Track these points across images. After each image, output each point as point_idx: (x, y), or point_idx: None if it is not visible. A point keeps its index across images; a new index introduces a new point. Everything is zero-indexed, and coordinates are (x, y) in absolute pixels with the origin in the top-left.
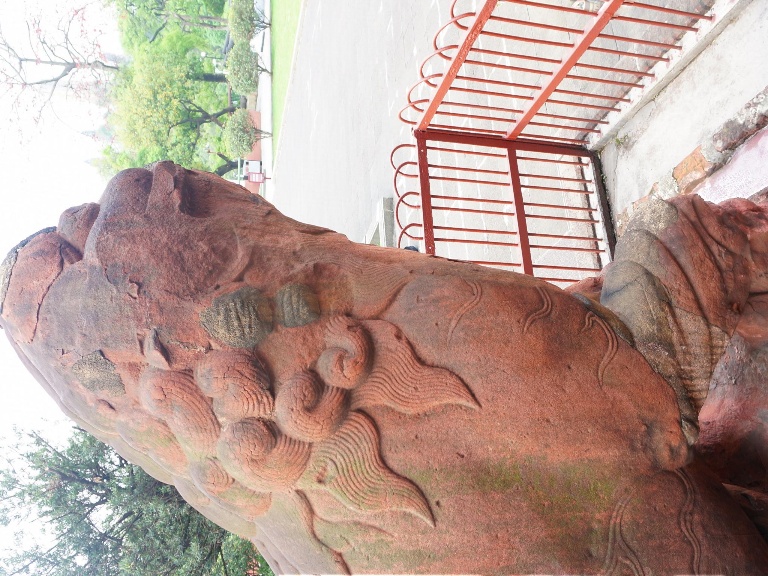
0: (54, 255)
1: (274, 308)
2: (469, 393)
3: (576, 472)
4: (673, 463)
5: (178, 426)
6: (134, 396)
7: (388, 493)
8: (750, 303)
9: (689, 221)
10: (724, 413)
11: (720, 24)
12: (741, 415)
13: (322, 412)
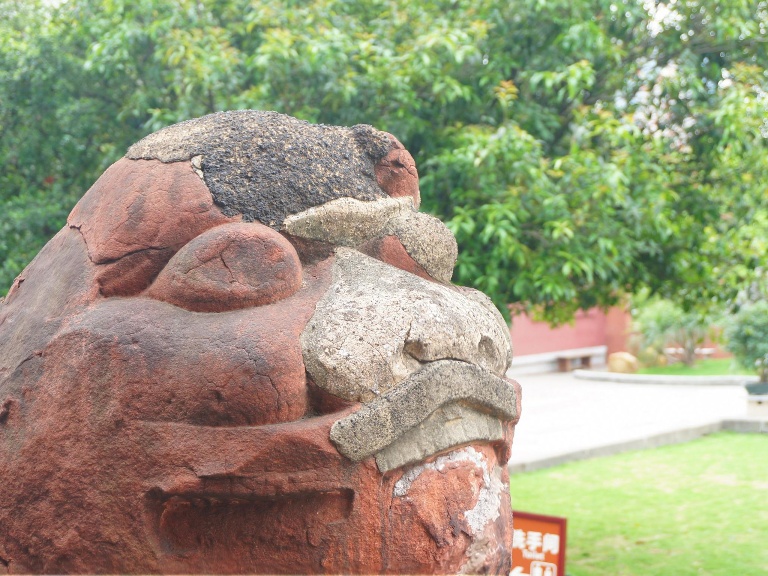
0: (123, 243)
1: None
2: None
3: None
4: None
5: None
6: None
7: None
8: None
9: None
10: None
11: None
12: None
13: None
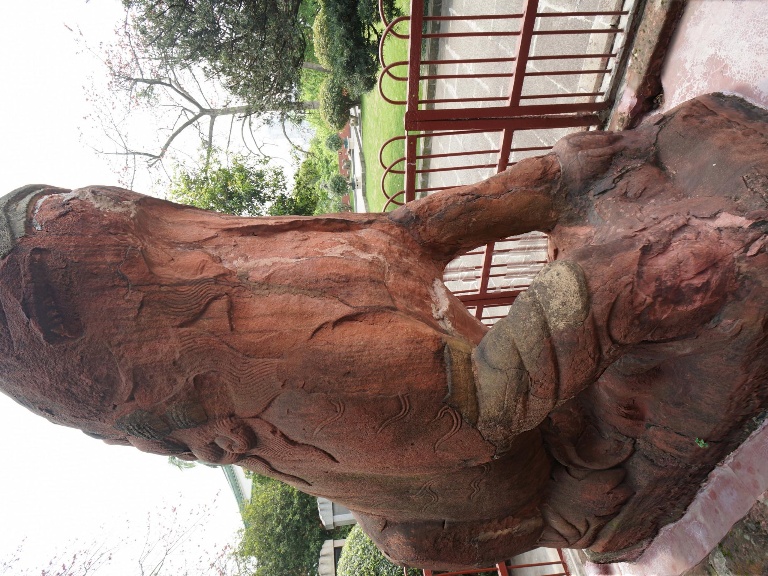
0: None
1: (167, 420)
2: (330, 458)
3: None
4: None
5: None
6: None
7: None
8: None
9: (593, 327)
10: None
11: None
12: None
13: None
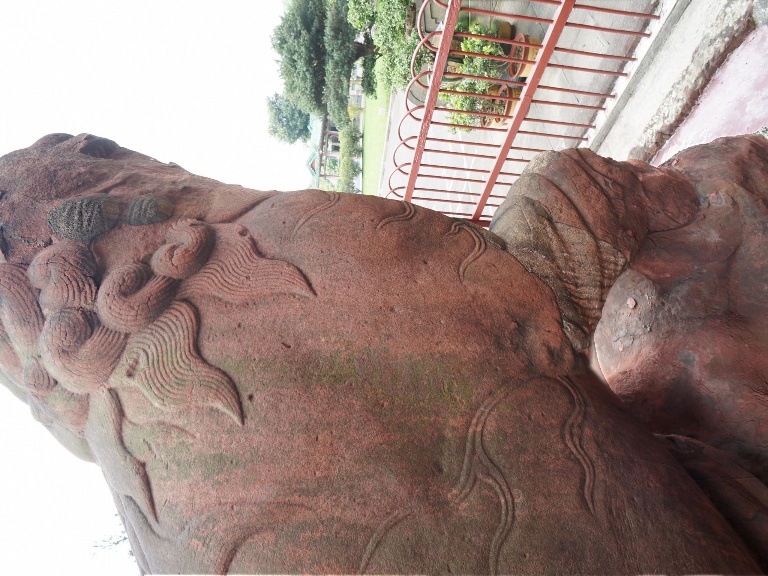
0: None
1: (124, 210)
2: (305, 281)
3: (425, 368)
4: (555, 369)
5: (7, 321)
6: None
7: (195, 385)
8: (650, 238)
9: (572, 159)
10: (641, 360)
11: (622, 99)
12: (660, 360)
13: (139, 297)
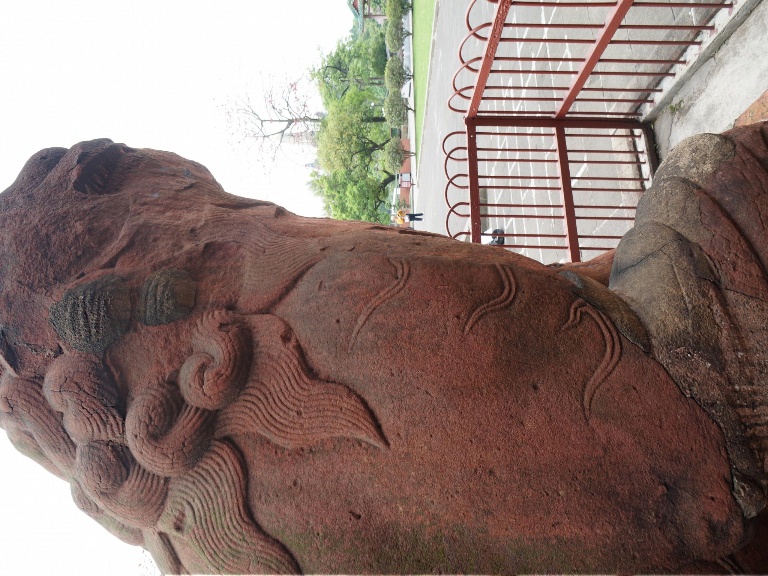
0: None
1: (136, 301)
2: (372, 424)
3: (537, 556)
4: (715, 548)
5: None
6: None
7: (252, 560)
8: None
9: (755, 158)
10: None
11: None
12: None
13: (171, 442)
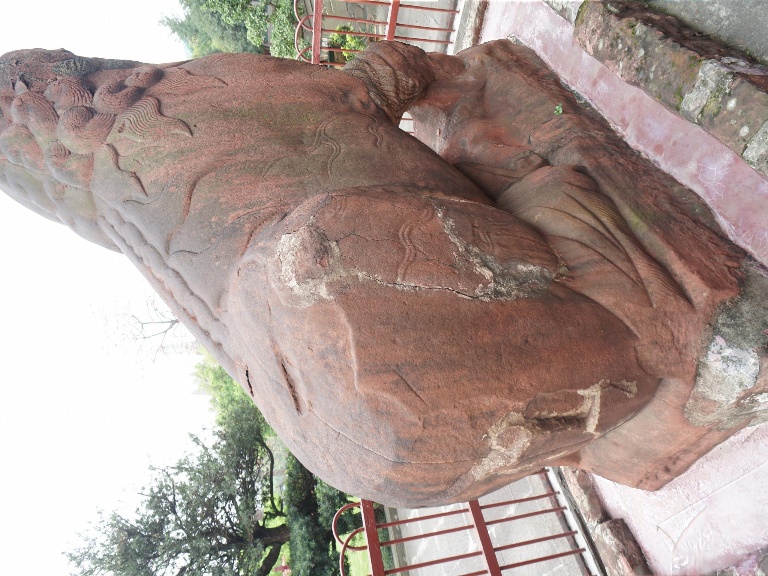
0: None
1: (102, 64)
2: None
3: (293, 109)
4: (366, 111)
5: (33, 123)
6: (9, 117)
7: (162, 125)
8: (435, 82)
9: None
10: (441, 152)
11: None
12: (450, 148)
13: (121, 93)
